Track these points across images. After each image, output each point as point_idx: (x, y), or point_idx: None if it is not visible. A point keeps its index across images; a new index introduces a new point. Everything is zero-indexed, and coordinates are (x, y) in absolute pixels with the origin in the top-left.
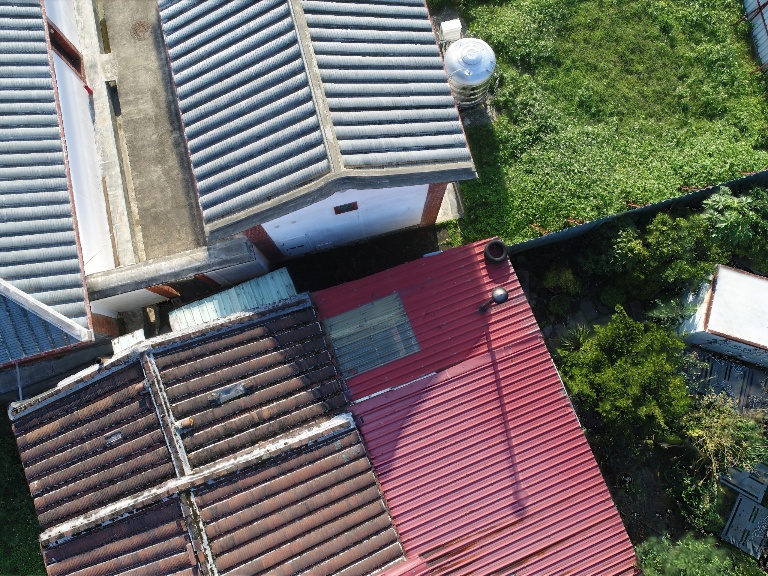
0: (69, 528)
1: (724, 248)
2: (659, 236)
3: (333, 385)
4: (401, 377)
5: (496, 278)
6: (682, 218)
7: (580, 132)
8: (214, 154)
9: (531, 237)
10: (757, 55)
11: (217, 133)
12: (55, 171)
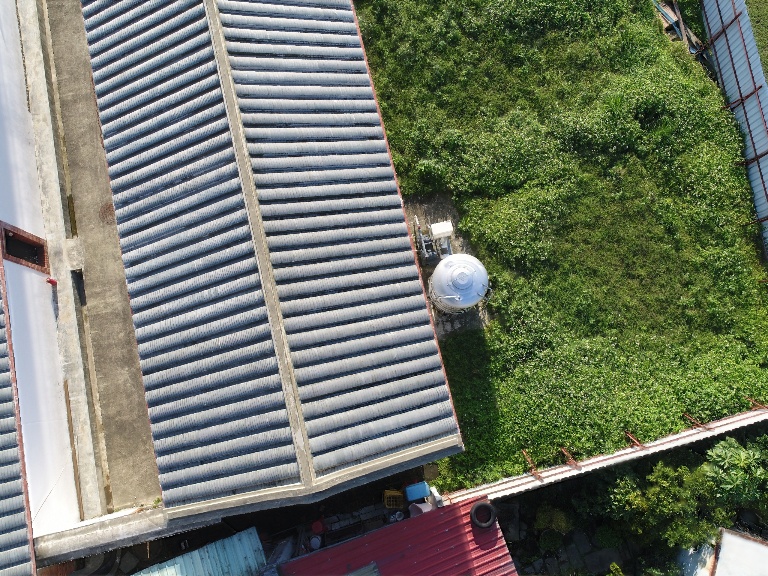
0: None
1: (729, 506)
2: (659, 492)
3: None
4: None
5: (482, 544)
6: (684, 466)
7: (577, 348)
8: (176, 429)
9: (522, 464)
10: (767, 259)
11: (179, 407)
12: (4, 427)
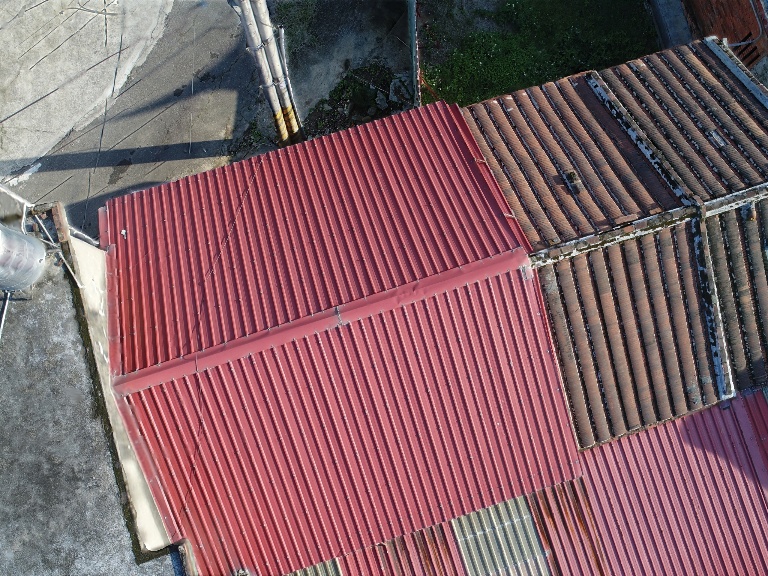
0: (615, 97)
1: None
2: None
3: (763, 376)
4: (766, 457)
5: None
6: None
7: None
8: None
9: None
10: None
11: None
12: None
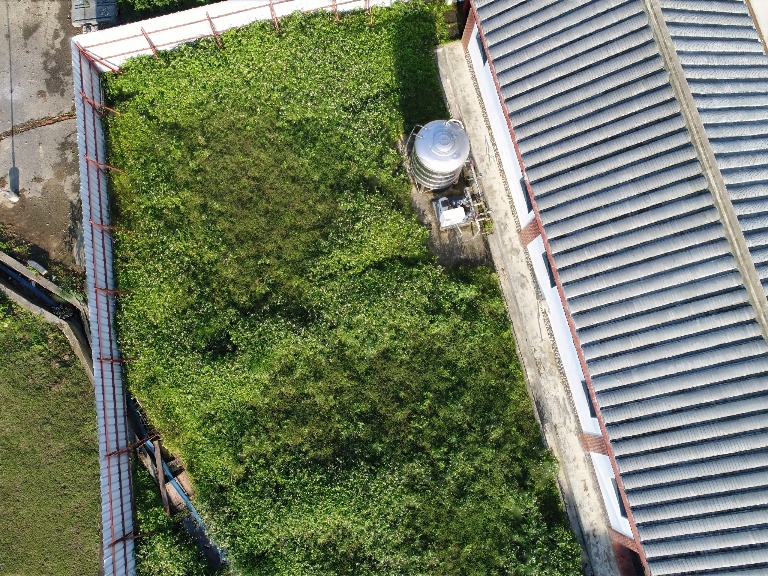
0: None
1: None
2: None
3: None
4: None
5: None
6: None
7: None
8: None
9: (373, 14)
10: None
11: None
12: None
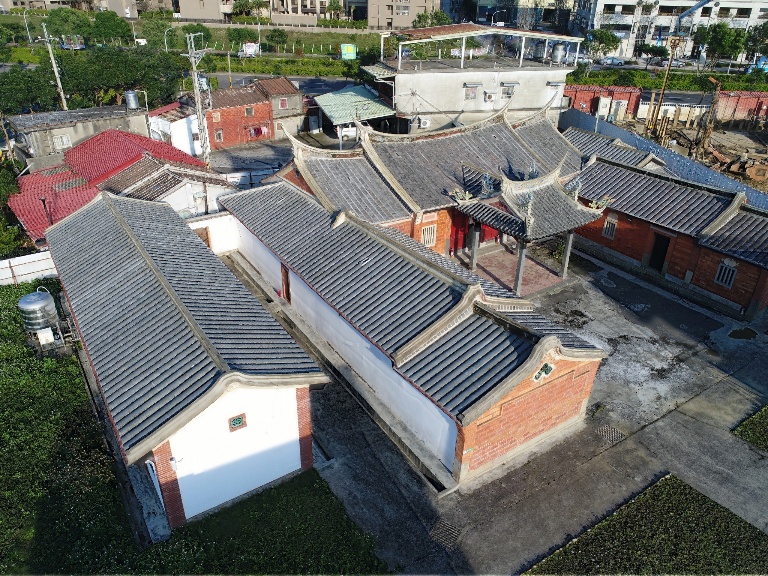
0: (211, 174)
1: None
2: None
3: None
4: None
5: None
6: None
7: None
8: None
9: None
10: None
11: None
12: None
